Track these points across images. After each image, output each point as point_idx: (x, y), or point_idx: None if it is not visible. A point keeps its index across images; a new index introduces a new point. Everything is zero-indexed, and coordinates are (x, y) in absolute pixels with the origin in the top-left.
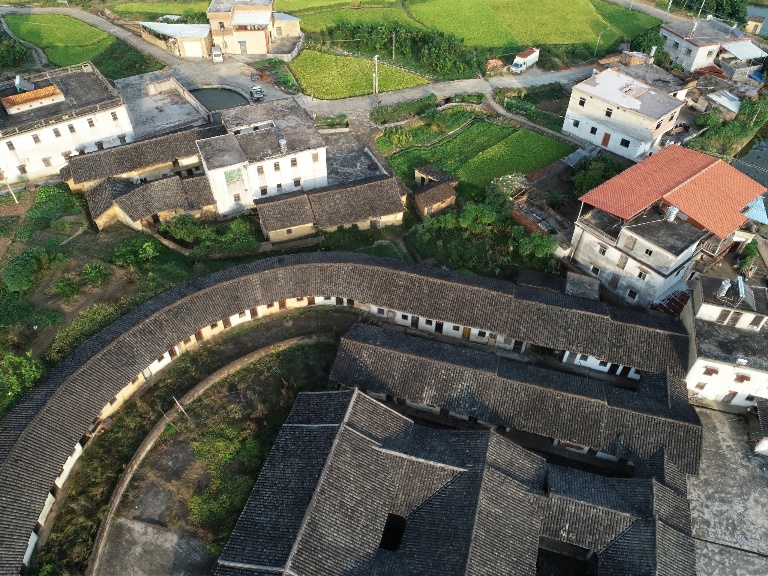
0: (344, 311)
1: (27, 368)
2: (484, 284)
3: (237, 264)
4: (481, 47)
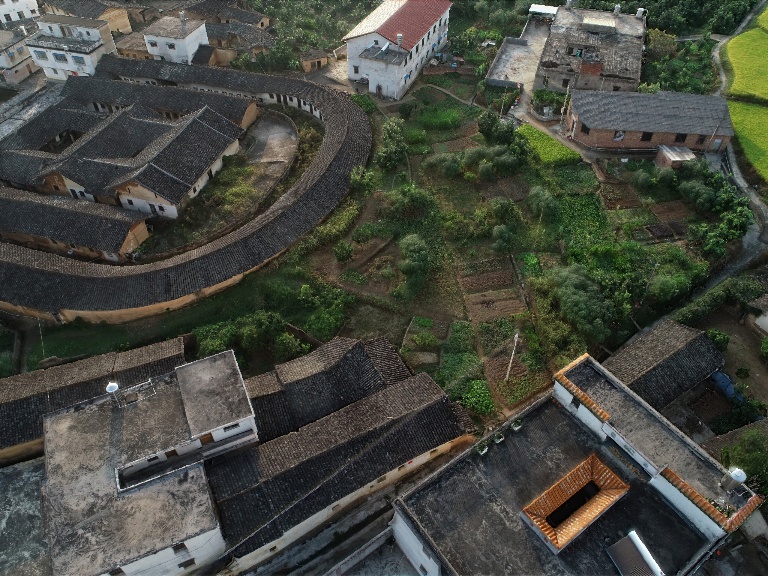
0: None
1: (354, 170)
2: None
3: (221, 316)
4: None
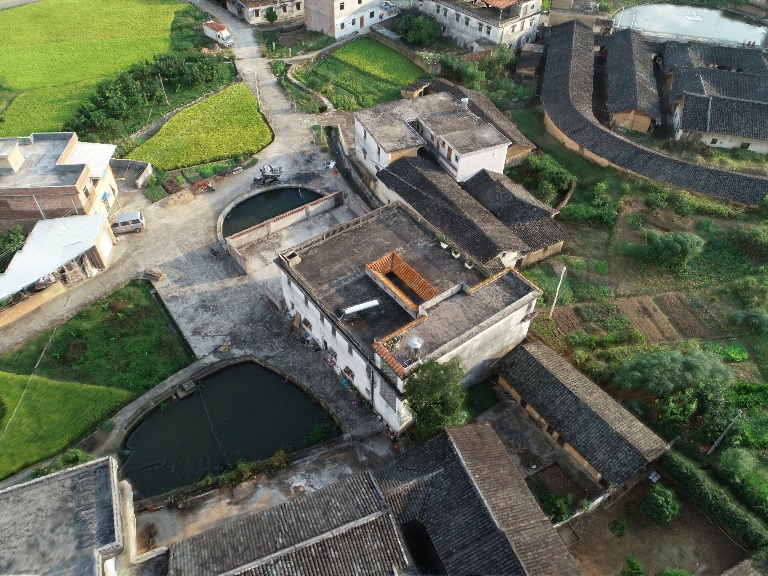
0: None
1: None
2: None
3: None
4: (171, 52)
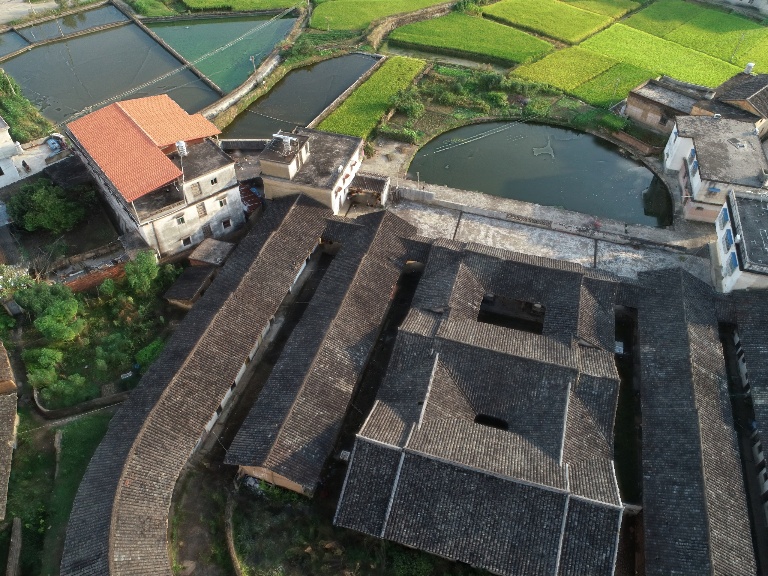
0: (181, 490)
1: None
2: (202, 318)
3: None
4: None
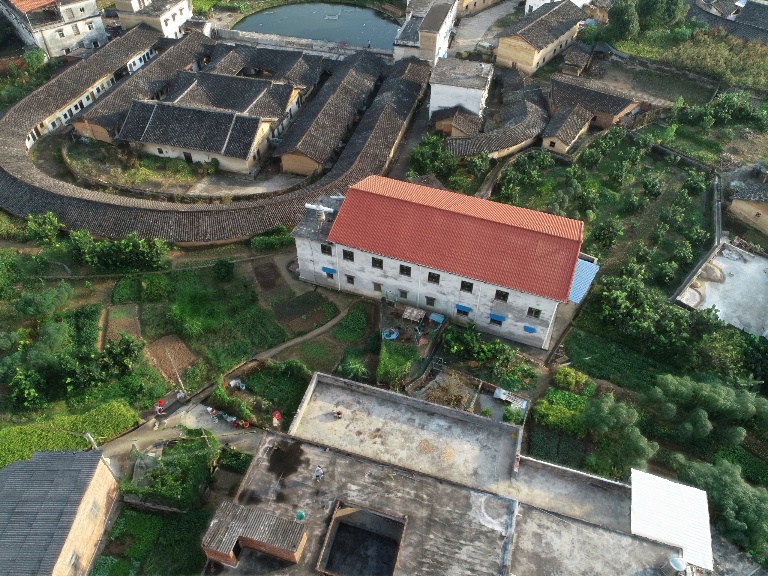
0: (42, 140)
1: (48, 212)
2: None
3: None
4: None
